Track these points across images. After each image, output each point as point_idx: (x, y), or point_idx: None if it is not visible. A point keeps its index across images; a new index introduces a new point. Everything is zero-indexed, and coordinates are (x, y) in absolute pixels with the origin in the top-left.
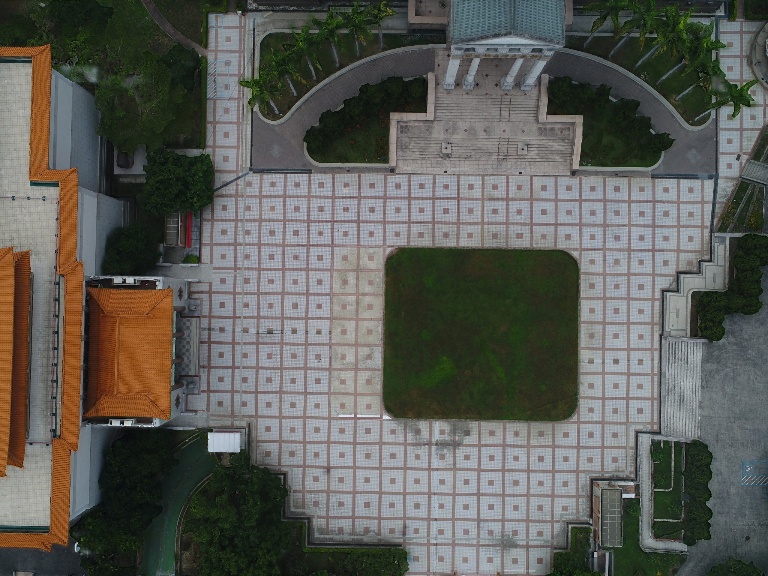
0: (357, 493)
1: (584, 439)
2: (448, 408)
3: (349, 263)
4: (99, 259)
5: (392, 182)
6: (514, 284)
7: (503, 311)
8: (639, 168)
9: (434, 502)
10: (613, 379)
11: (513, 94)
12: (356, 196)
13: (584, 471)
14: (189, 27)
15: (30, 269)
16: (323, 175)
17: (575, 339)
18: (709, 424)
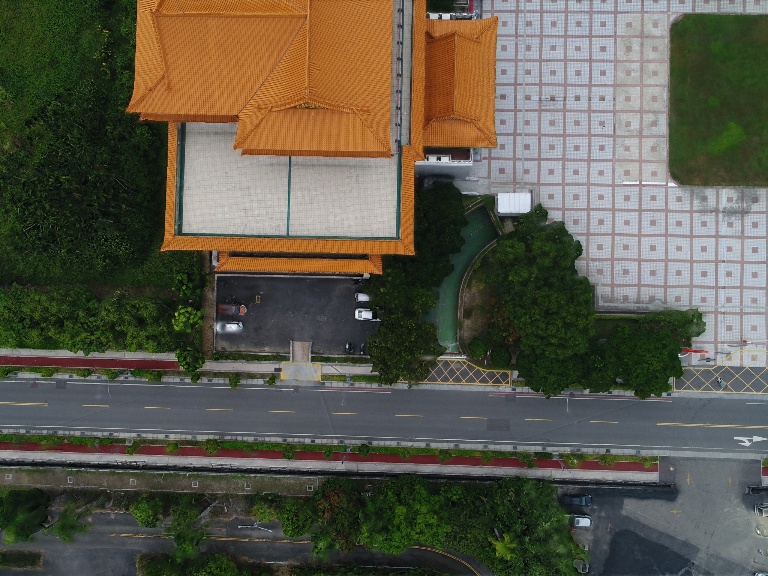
0: (642, 261)
1: None
2: (736, 175)
3: (633, 30)
4: None
5: None
6: None
7: None
8: None
9: (722, 270)
10: None
11: None
12: None
13: None
14: None
15: None
16: None
17: None
18: None
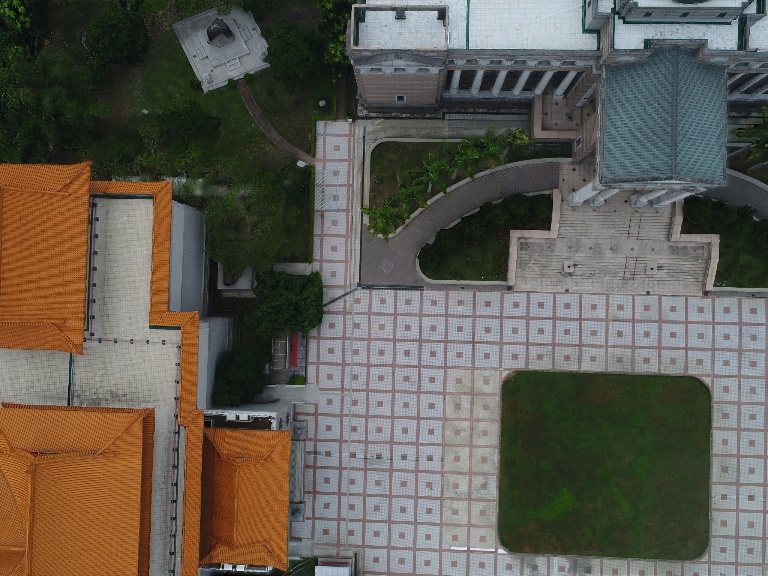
0: None
1: None
2: (568, 543)
3: (463, 386)
4: (209, 390)
5: (509, 300)
6: (640, 412)
7: (628, 441)
8: None
9: None
10: (748, 517)
11: (644, 211)
12: (471, 315)
13: None
14: (296, 135)
15: (154, 426)
16: (436, 292)
17: (706, 473)
18: None
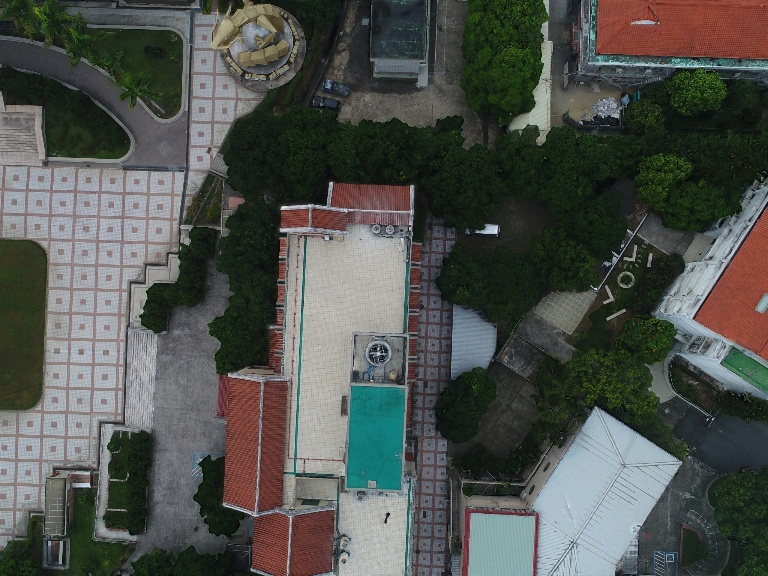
0: None
1: (48, 428)
2: None
3: None
4: None
5: None
6: None
7: None
8: (108, 160)
9: None
10: (78, 369)
11: None
12: None
13: (47, 460)
14: None
15: None
16: None
17: (41, 329)
18: (162, 415)
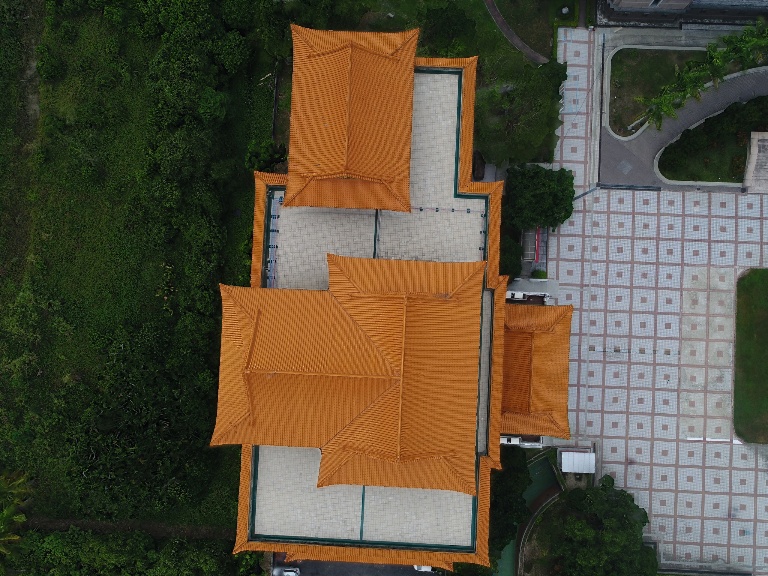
0: (706, 519)
1: None
2: None
3: (699, 283)
4: None
5: (743, 202)
6: None
7: None
8: None
9: None
10: None
11: None
12: (707, 215)
13: None
14: (538, 41)
15: None
16: (672, 193)
17: None
18: None
